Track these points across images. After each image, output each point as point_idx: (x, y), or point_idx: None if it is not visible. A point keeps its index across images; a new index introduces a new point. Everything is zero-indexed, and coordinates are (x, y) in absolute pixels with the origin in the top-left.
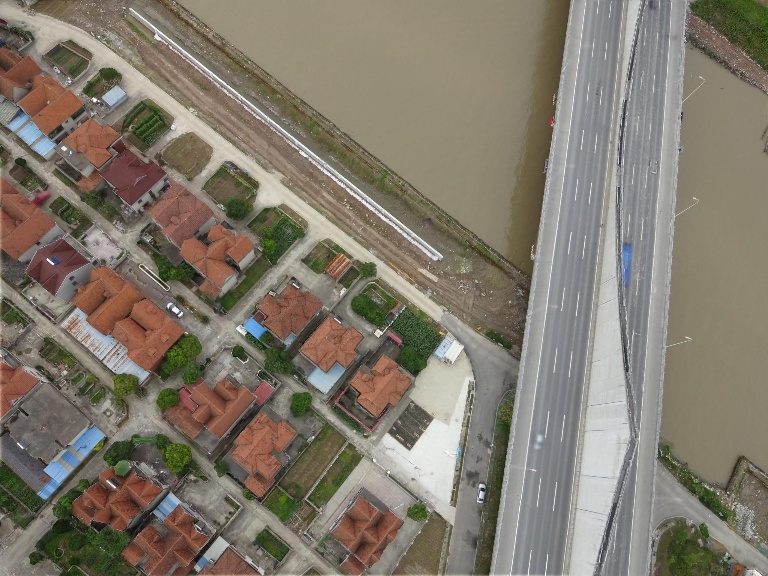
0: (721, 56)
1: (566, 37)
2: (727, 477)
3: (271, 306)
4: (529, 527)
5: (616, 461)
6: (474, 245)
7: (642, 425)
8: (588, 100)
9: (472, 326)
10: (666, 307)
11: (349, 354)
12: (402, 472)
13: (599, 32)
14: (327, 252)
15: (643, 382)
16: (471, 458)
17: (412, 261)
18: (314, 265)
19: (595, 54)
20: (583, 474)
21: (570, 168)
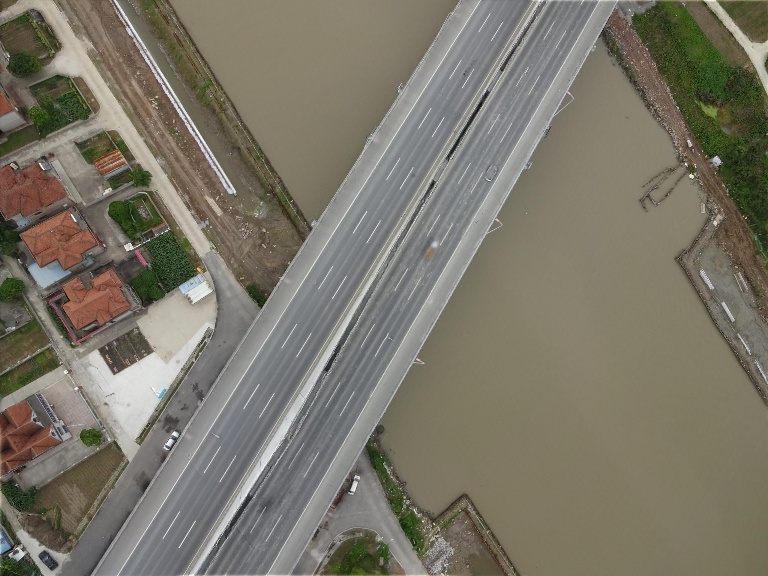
0: (641, 83)
1: (459, 0)
2: (442, 509)
3: (3, 178)
4: (187, 489)
5: (270, 455)
6: (276, 191)
7: (353, 430)
8: (451, 78)
9: (235, 273)
10: (434, 322)
11: (71, 256)
12: (97, 393)
13: (499, 8)
14: (108, 145)
15: (374, 388)
16: (177, 403)
17: (202, 185)
18: (88, 153)
19: (483, 30)
20: (261, 457)
21: (397, 144)
